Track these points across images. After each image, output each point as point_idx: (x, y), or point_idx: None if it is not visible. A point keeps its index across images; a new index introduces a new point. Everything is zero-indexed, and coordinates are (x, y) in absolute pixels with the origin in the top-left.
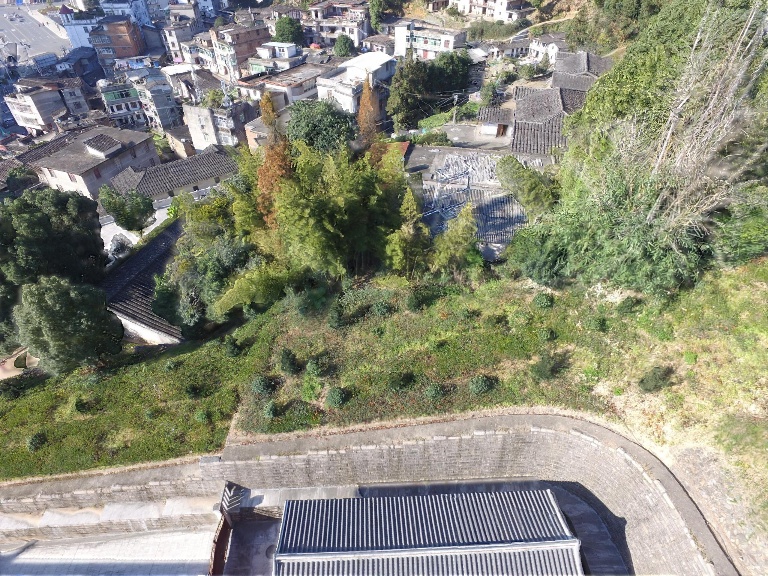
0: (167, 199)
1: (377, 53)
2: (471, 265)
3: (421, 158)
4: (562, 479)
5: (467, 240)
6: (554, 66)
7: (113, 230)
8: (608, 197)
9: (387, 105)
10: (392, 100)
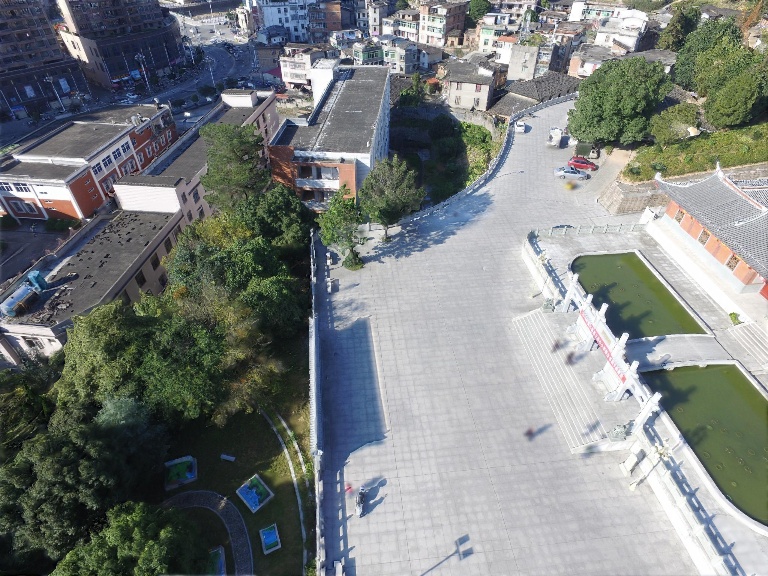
0: (561, 97)
1: (635, 10)
2: None
3: None
4: None
5: None
6: (767, 17)
7: (548, 112)
8: None
9: (660, 43)
10: (666, 39)
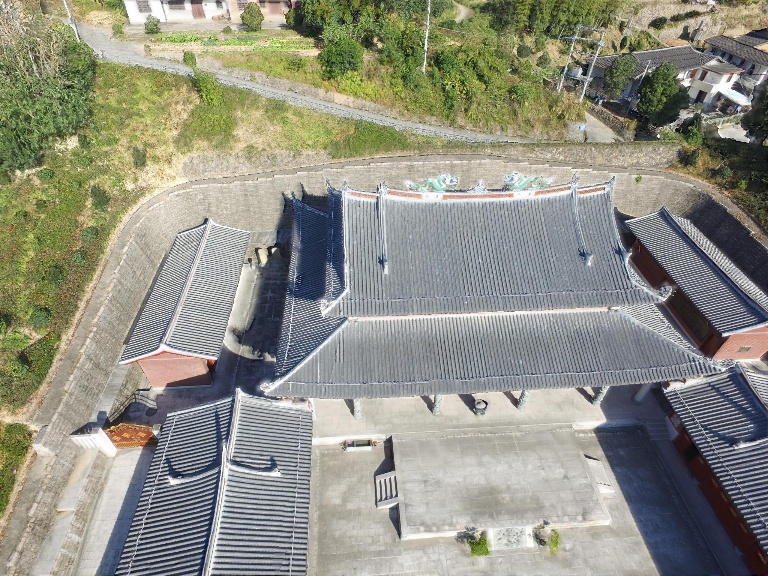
0: None
1: None
2: None
3: None
4: (173, 240)
5: None
6: None
7: None
8: (3, 79)
9: None
10: None
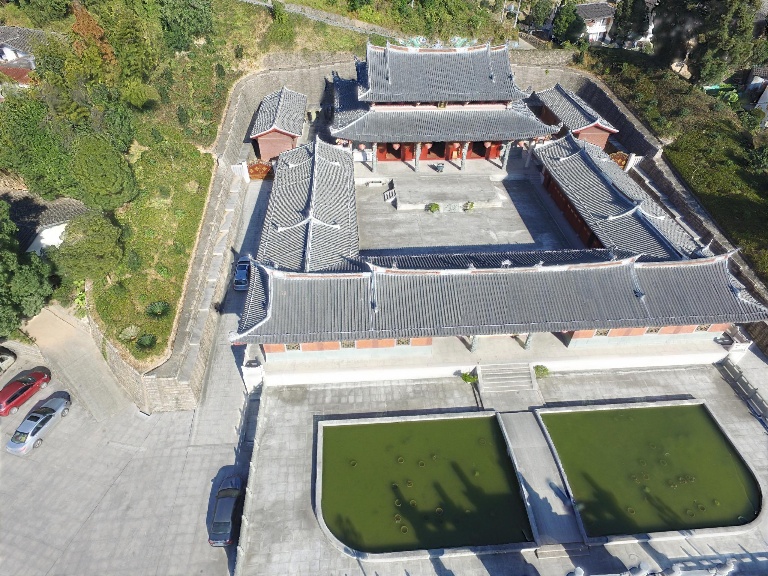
0: None
1: None
2: (162, 56)
3: (22, 66)
4: (258, 105)
5: (162, 34)
6: None
7: None
8: None
9: None
10: None
